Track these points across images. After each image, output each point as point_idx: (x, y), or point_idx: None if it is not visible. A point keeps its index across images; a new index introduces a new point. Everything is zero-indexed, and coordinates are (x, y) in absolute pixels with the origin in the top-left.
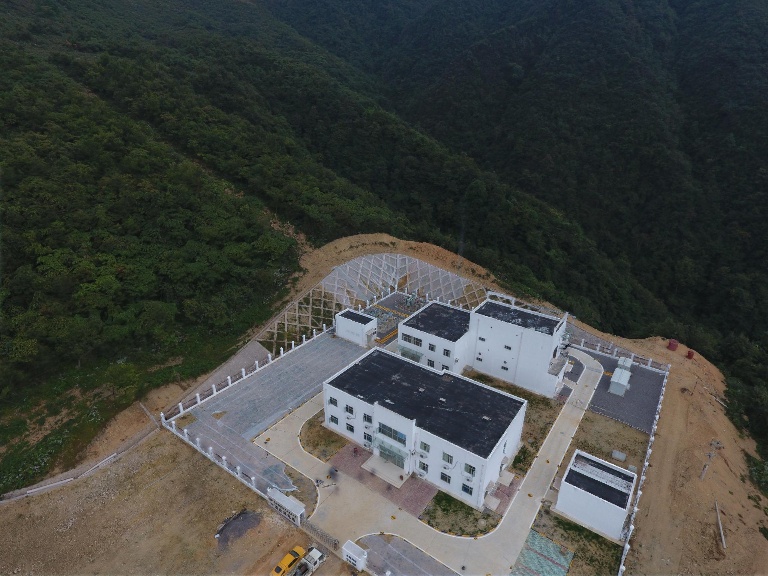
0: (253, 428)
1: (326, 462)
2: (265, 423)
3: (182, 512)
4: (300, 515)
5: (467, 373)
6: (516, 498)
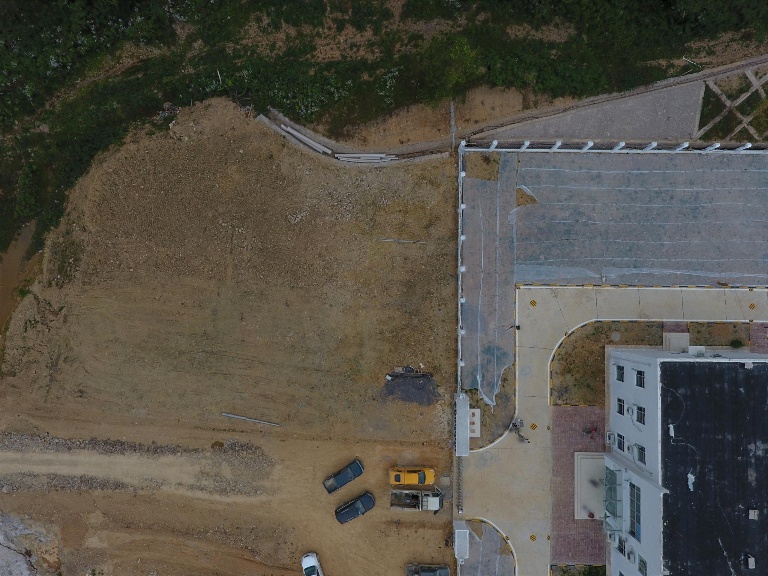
0: (536, 267)
1: (552, 405)
2: (555, 273)
3: (385, 312)
4: None
5: None
6: None
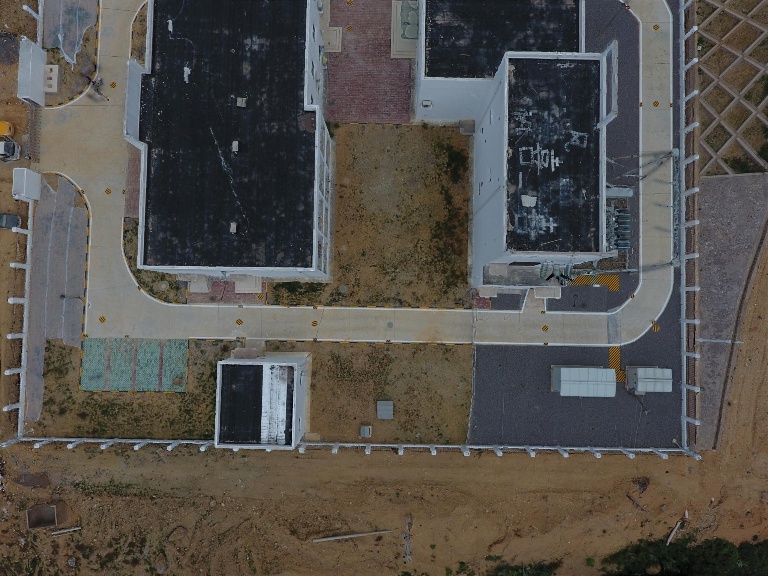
0: None
1: None
2: None
3: None
4: (25, 98)
5: (454, 132)
6: (224, 308)
